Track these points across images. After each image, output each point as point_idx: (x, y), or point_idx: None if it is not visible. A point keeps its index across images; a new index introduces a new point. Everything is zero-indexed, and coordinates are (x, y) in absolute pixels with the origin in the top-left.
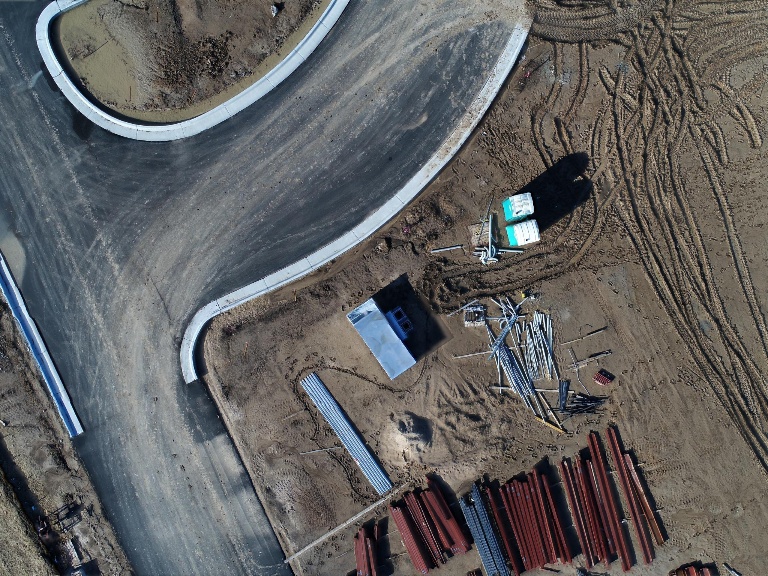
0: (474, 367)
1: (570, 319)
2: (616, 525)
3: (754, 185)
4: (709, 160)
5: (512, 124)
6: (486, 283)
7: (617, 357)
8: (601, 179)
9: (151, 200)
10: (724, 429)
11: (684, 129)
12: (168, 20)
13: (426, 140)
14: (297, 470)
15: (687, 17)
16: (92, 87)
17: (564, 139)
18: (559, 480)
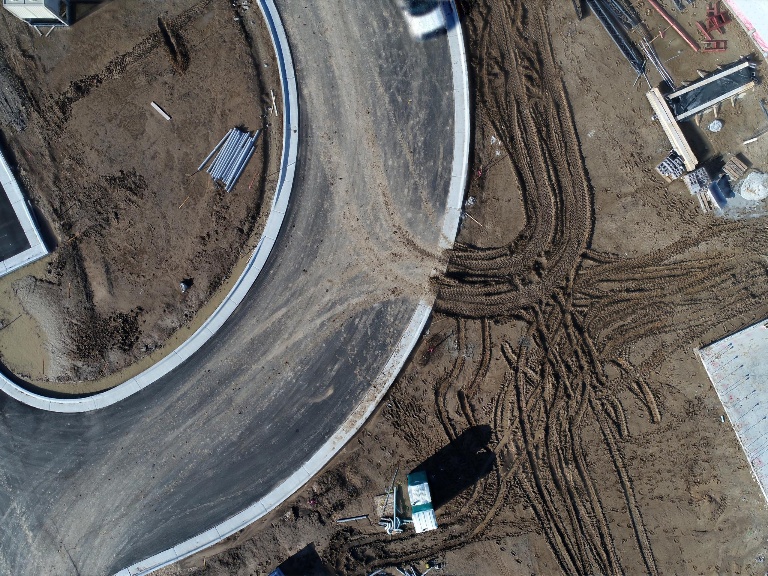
0: None
1: None
2: None
3: (654, 459)
4: (610, 434)
5: (416, 397)
6: (391, 552)
7: None
8: (504, 451)
9: (64, 470)
10: None
11: (585, 403)
12: (80, 296)
13: (332, 413)
14: None
15: (587, 294)
16: (6, 359)
17: (467, 412)
18: None
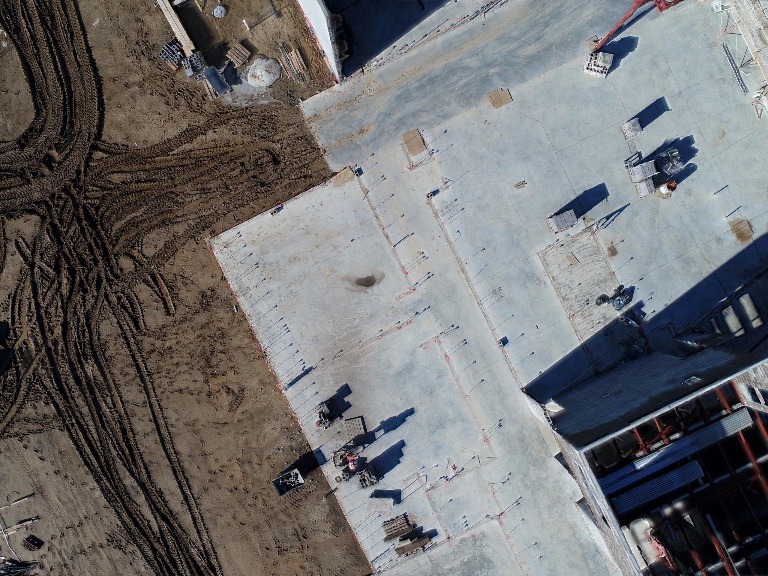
0: None
1: None
2: None
3: (172, 351)
4: (127, 327)
5: None
6: None
7: (45, 523)
8: (23, 348)
9: None
10: None
11: (101, 297)
12: None
13: None
14: None
15: (99, 187)
16: None
17: None
18: None
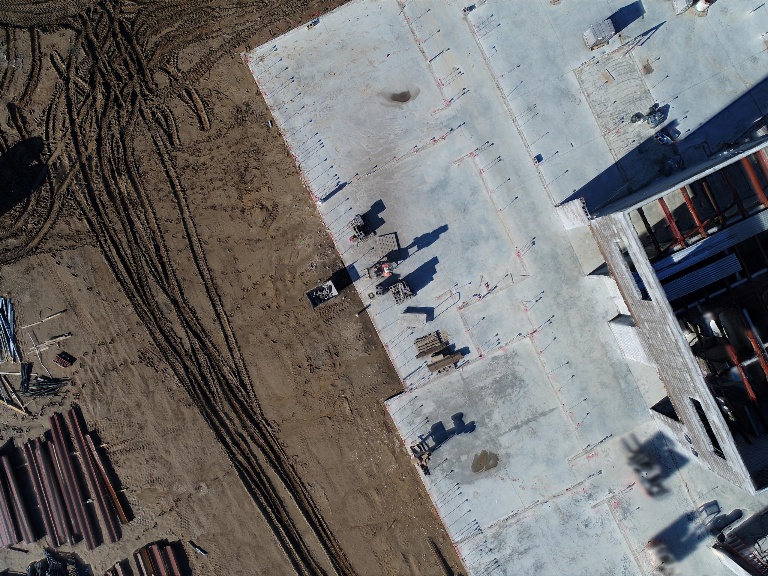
0: None
1: (30, 303)
2: (80, 505)
3: (206, 167)
4: (161, 143)
5: None
6: None
7: (77, 340)
8: (57, 163)
9: None
10: (185, 409)
11: (136, 112)
12: None
13: None
14: None
15: (134, 1)
16: None
17: (20, 124)
18: (25, 462)
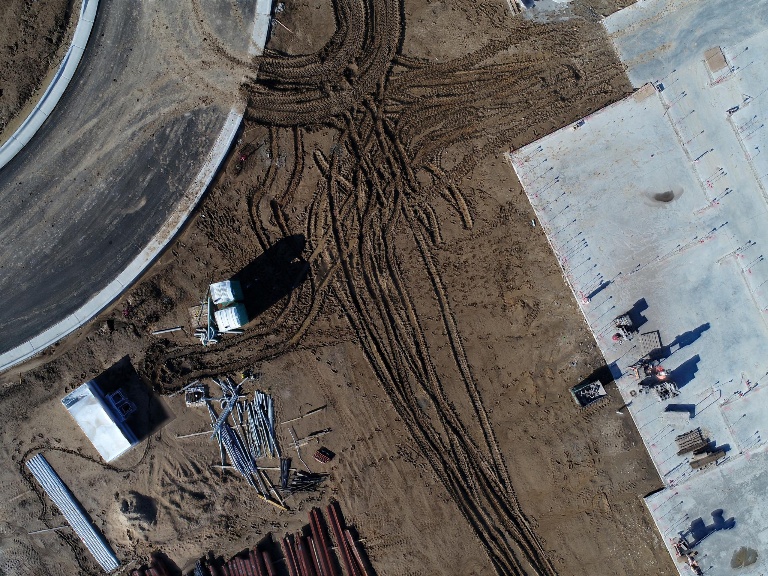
0: (197, 446)
1: (290, 398)
2: None
3: (467, 265)
4: (423, 241)
5: (230, 207)
6: (207, 364)
7: (337, 435)
8: (318, 260)
9: None
10: (443, 504)
11: (398, 211)
12: None
13: (145, 224)
14: (26, 549)
15: (398, 100)
16: None
17: (281, 221)
18: (282, 556)
